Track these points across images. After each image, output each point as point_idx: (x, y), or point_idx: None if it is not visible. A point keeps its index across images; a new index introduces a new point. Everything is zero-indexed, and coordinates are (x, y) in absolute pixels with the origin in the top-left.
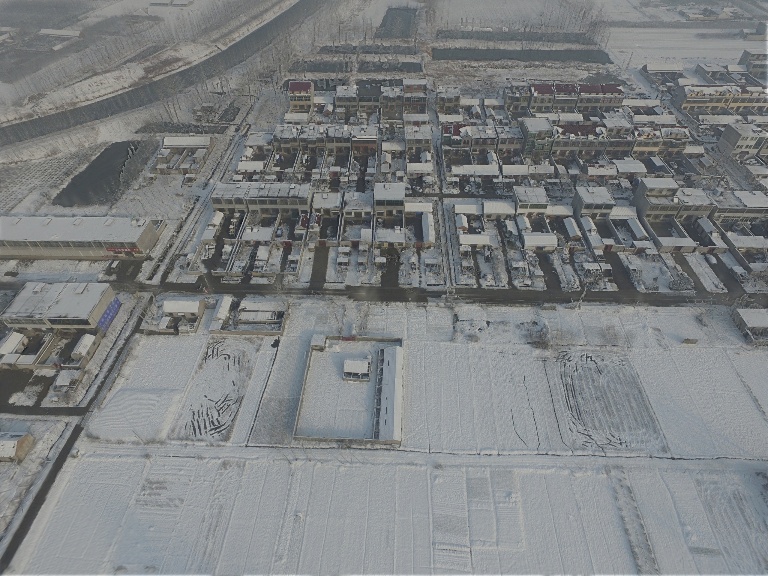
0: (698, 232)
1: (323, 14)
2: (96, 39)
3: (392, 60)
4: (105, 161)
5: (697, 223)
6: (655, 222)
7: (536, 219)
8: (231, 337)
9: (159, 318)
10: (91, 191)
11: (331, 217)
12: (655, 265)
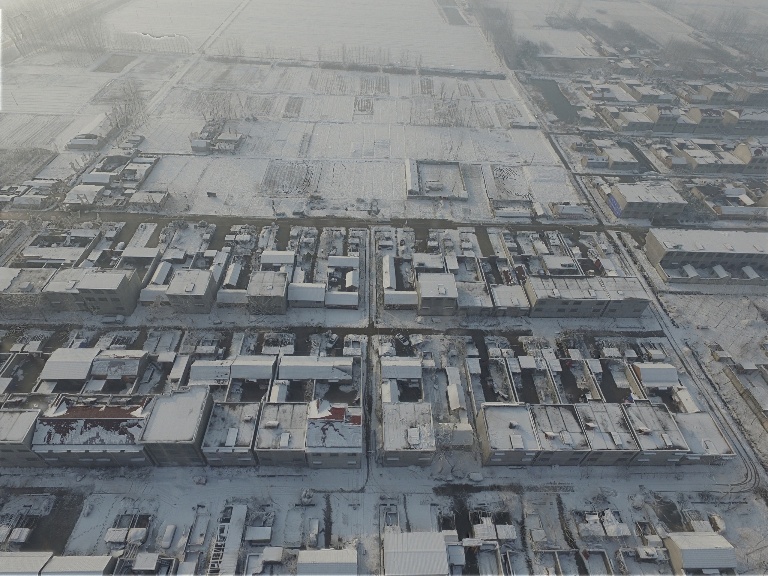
0: None
1: None
2: None
3: None
4: None
5: None
6: None
7: None
8: None
9: None
10: None
11: None
12: (179, 245)
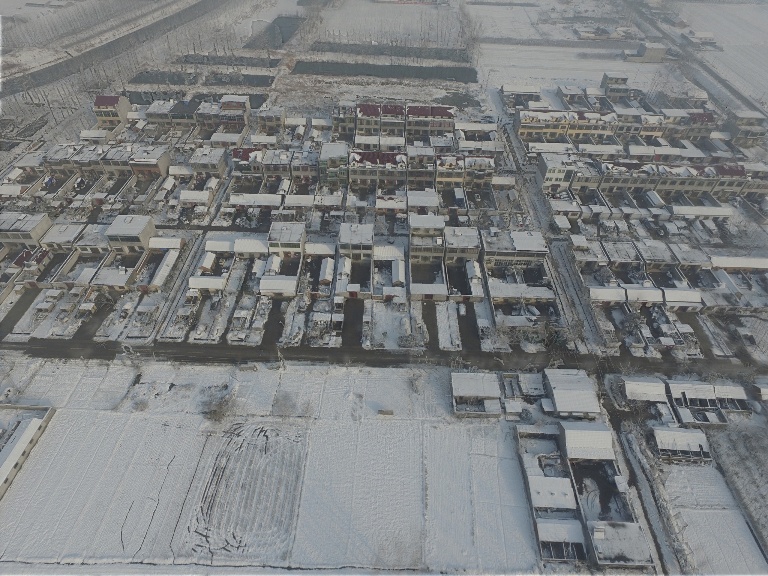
0: (465, 276)
1: (200, 21)
2: None
3: (234, 73)
4: None
5: None
6: (424, 264)
7: (295, 258)
8: None
9: None
10: None
11: (66, 252)
12: (398, 316)
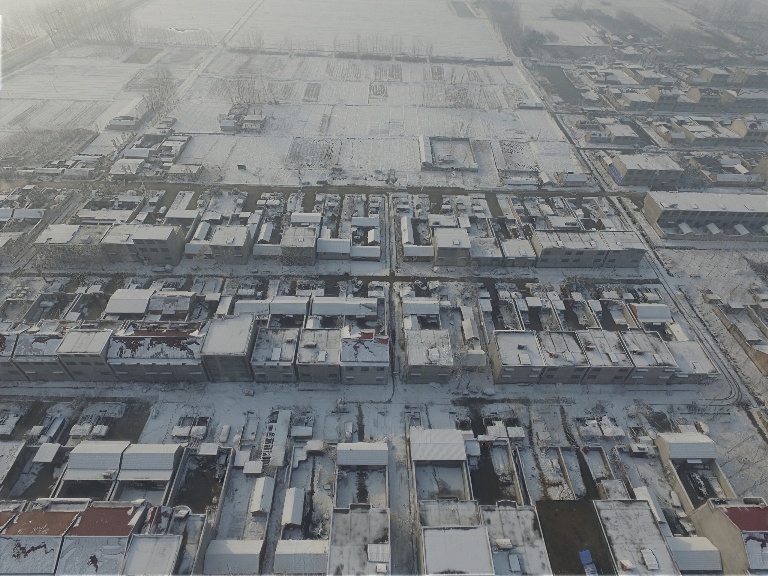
0: None
1: None
2: None
3: None
4: None
5: None
6: None
7: None
8: None
9: None
10: None
11: None
12: (215, 209)
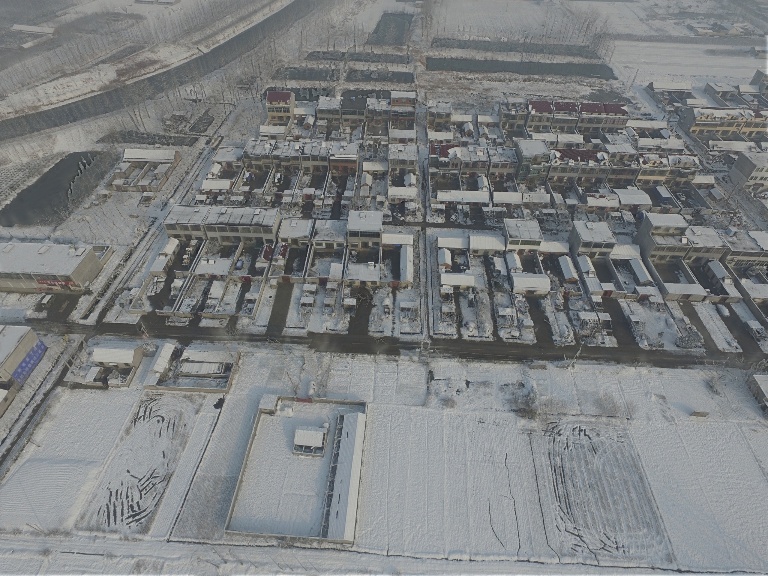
0: (708, 276)
1: (314, 17)
2: (71, 37)
3: (382, 70)
4: (59, 173)
5: (707, 266)
6: (660, 263)
7: (528, 256)
8: (169, 394)
9: (88, 367)
10: (37, 208)
11: (299, 247)
12: (660, 315)
